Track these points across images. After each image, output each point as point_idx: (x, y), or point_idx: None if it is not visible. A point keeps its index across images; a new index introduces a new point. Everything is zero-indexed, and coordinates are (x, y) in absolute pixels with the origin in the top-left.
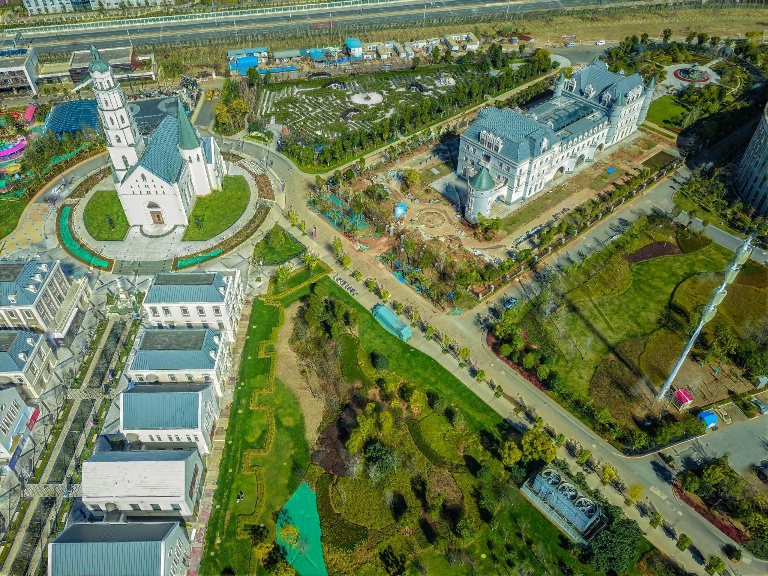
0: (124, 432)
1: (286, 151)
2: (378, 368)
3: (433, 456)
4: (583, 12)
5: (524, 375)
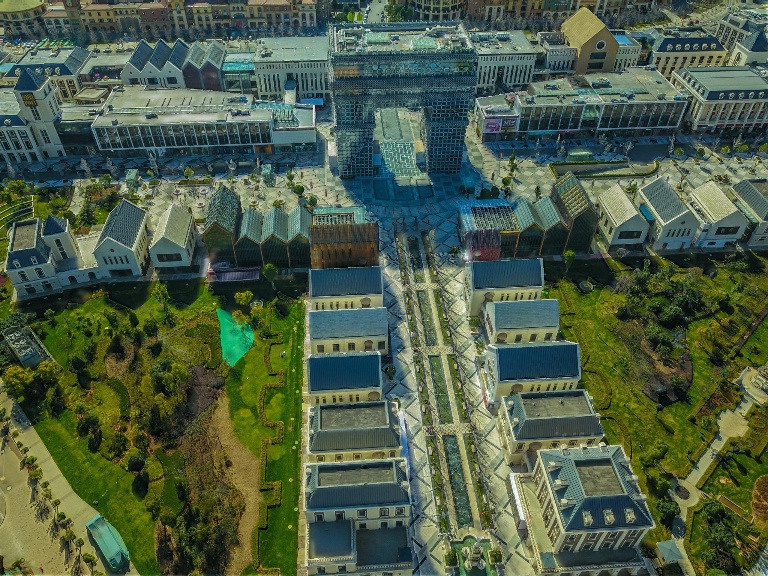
0: None
1: None
2: None
3: (117, 384)
4: None
5: None
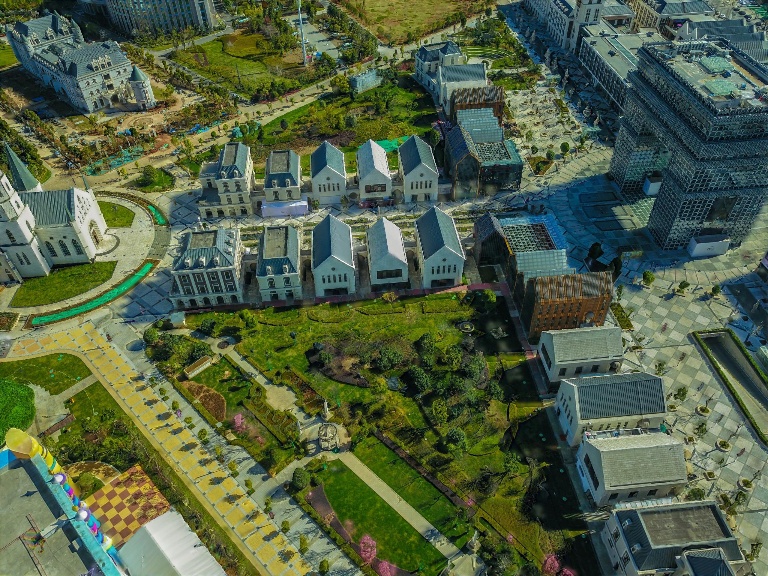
0: None
1: None
2: None
3: None
4: None
5: (291, 94)
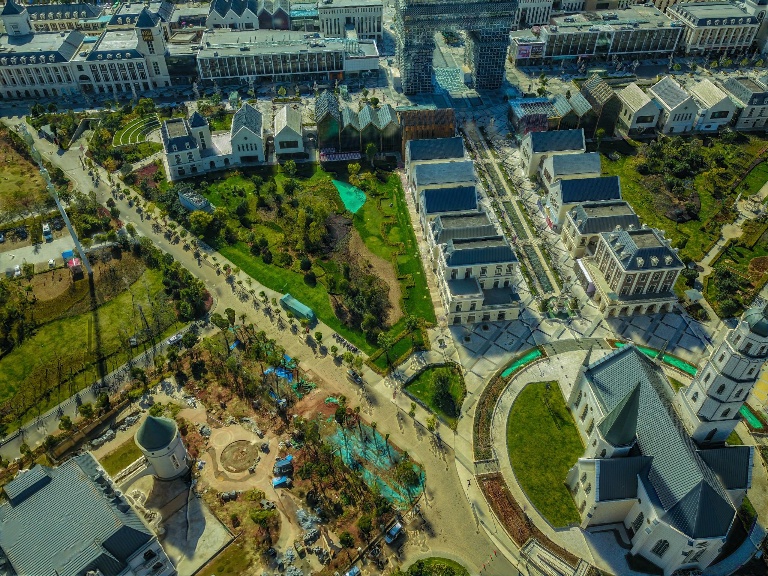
0: None
1: None
2: None
3: (272, 224)
4: None
5: None
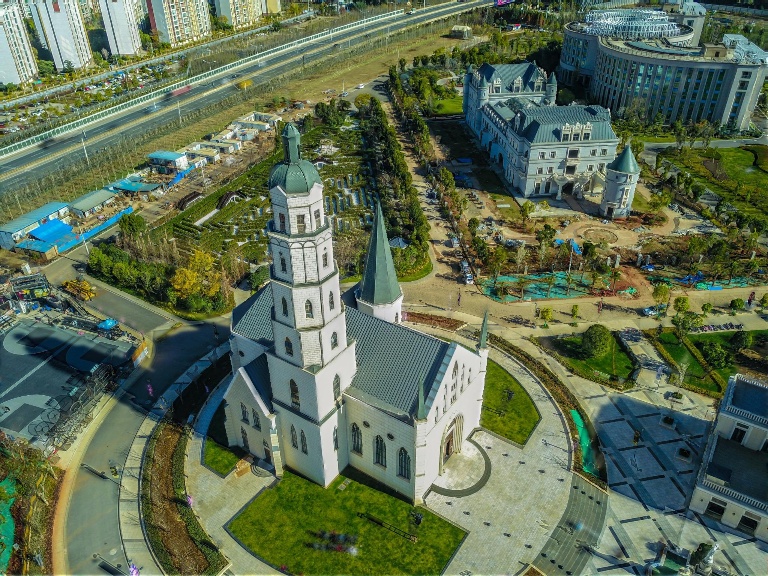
0: None
1: (346, 276)
2: None
3: None
4: (292, 77)
5: None
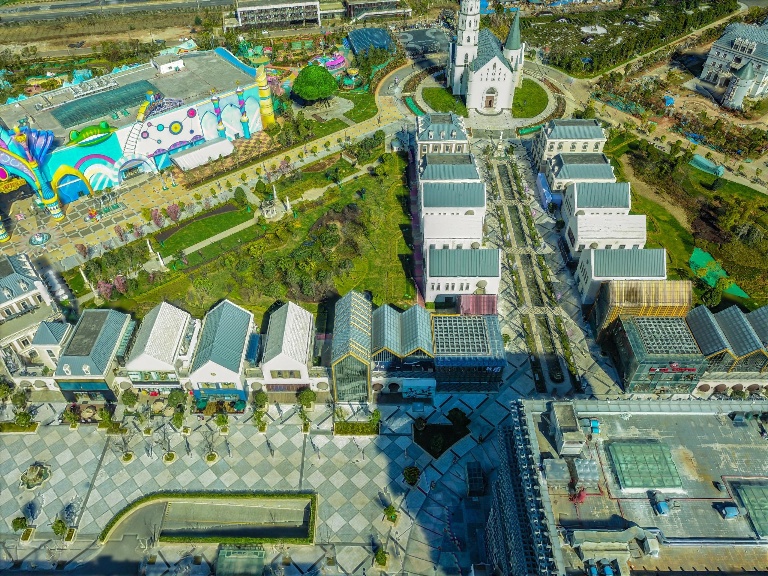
0: (578, 209)
1: (552, 64)
2: (716, 187)
3: None
4: None
5: None
